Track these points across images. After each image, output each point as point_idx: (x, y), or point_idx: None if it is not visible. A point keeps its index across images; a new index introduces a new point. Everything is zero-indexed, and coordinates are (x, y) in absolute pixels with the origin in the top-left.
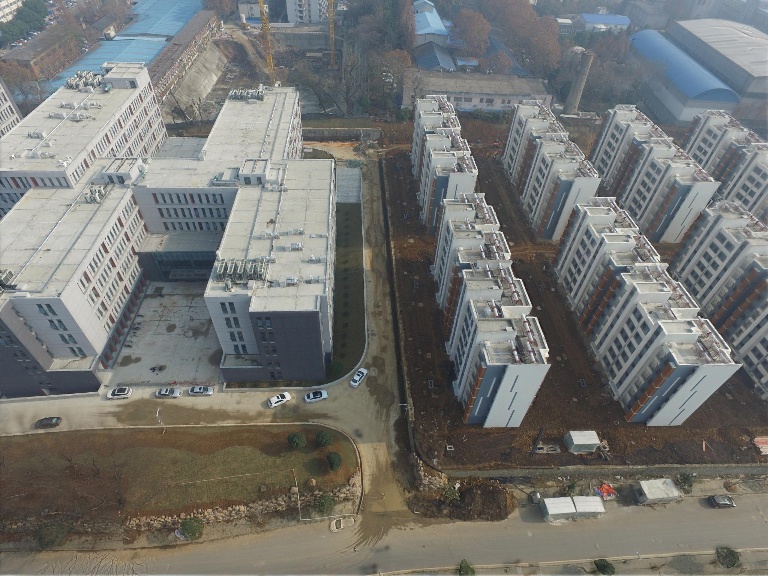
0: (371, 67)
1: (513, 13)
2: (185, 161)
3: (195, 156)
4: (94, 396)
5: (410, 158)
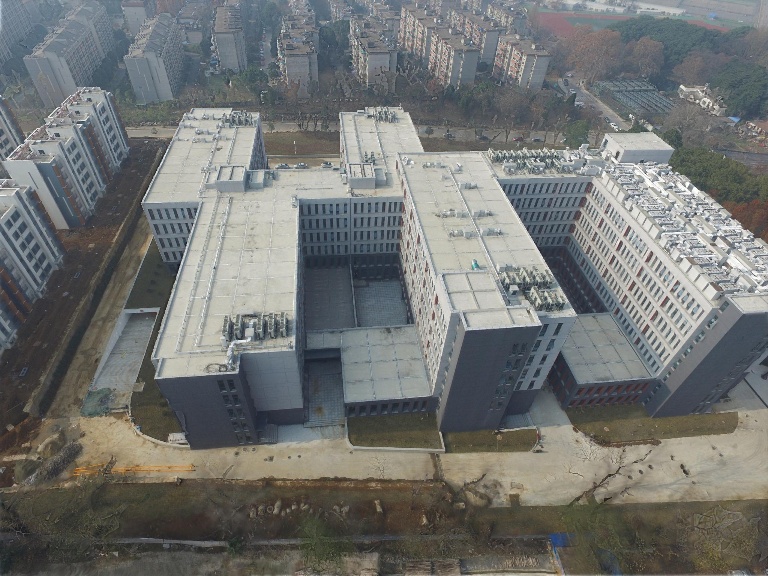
0: None
1: None
2: None
3: (364, 350)
4: None
5: None
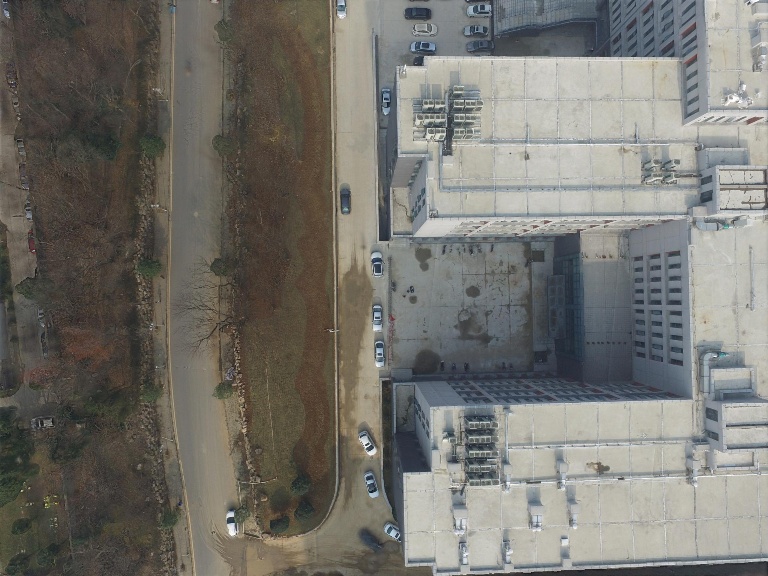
0: None
1: None
2: None
3: None
4: None
5: None
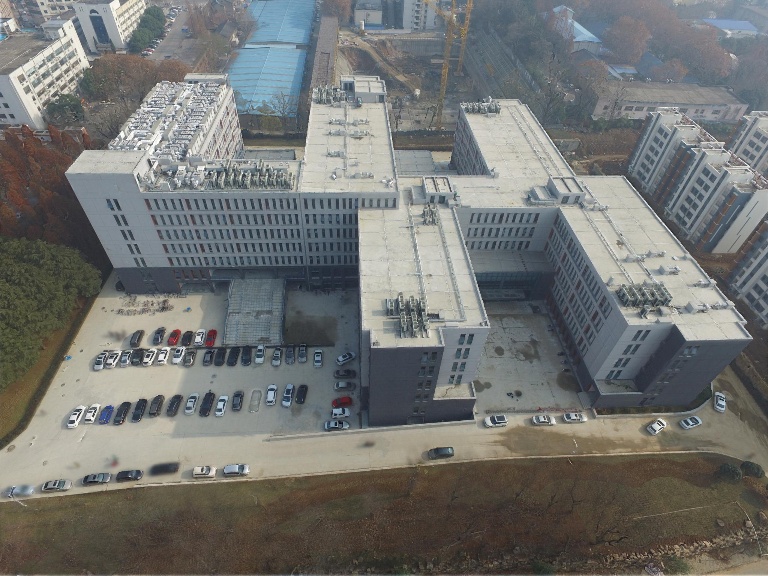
0: (536, 76)
1: (665, 20)
2: (480, 179)
3: (421, 170)
4: (469, 424)
5: (631, 170)
